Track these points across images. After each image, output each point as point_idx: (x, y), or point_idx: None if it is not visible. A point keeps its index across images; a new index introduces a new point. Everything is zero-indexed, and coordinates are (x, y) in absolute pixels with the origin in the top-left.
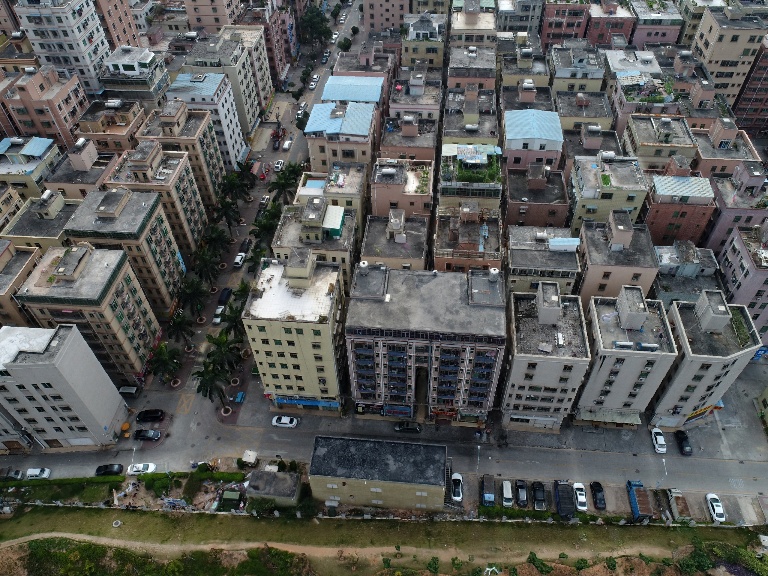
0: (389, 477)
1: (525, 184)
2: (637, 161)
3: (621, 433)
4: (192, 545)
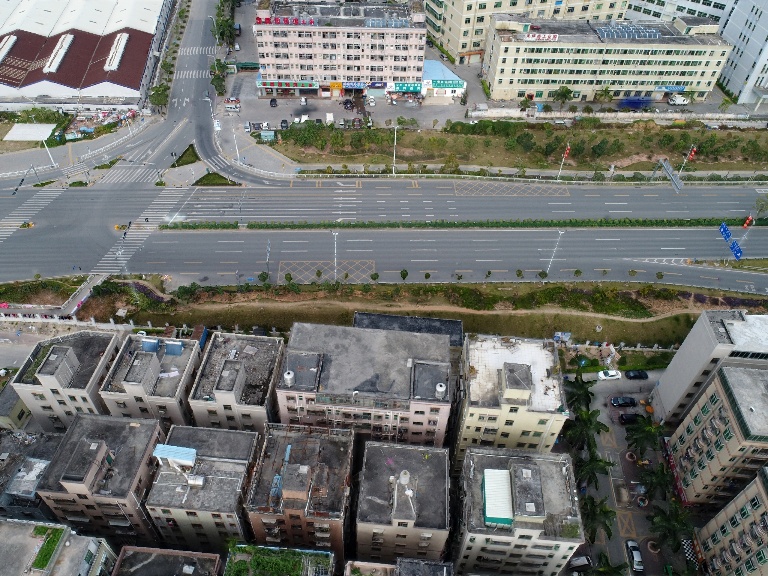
0: (398, 319)
1: None
2: None
3: None
4: (536, 312)
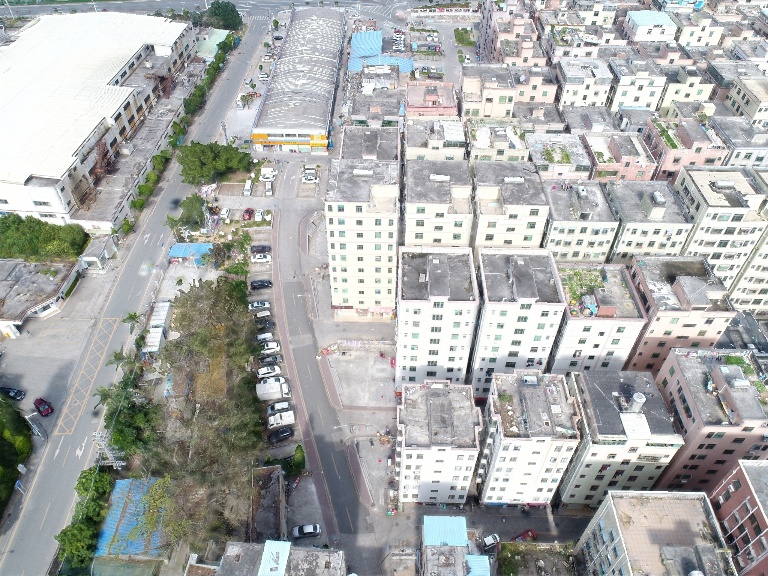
0: None
1: None
2: None
3: None
4: None
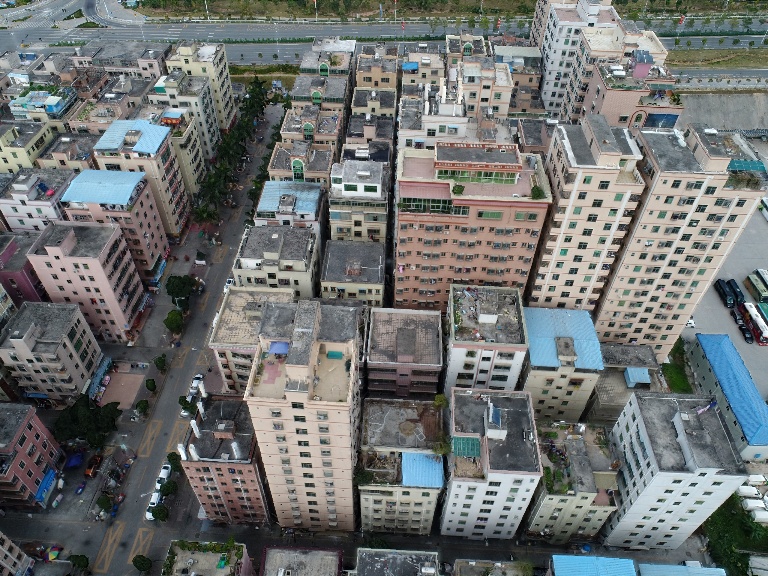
0: None
1: (5, 116)
2: None
3: None
4: (267, 75)
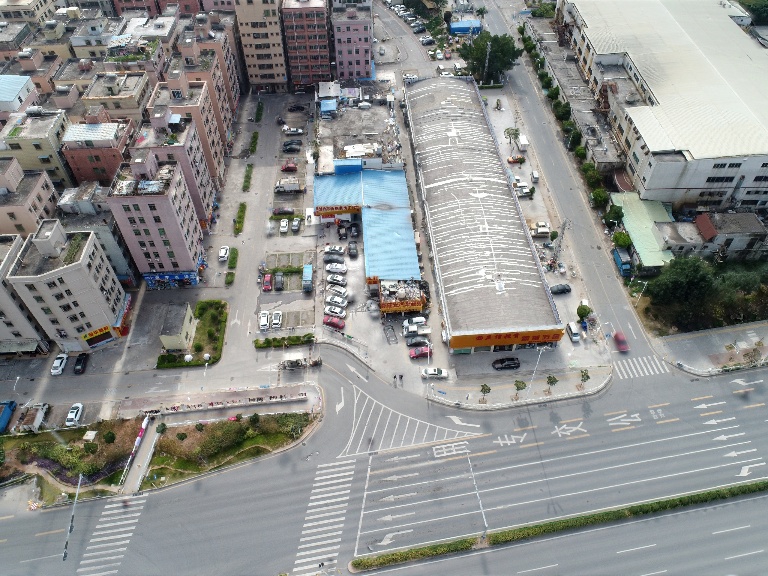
0: None
1: None
2: (61, 113)
3: (31, 362)
4: None
